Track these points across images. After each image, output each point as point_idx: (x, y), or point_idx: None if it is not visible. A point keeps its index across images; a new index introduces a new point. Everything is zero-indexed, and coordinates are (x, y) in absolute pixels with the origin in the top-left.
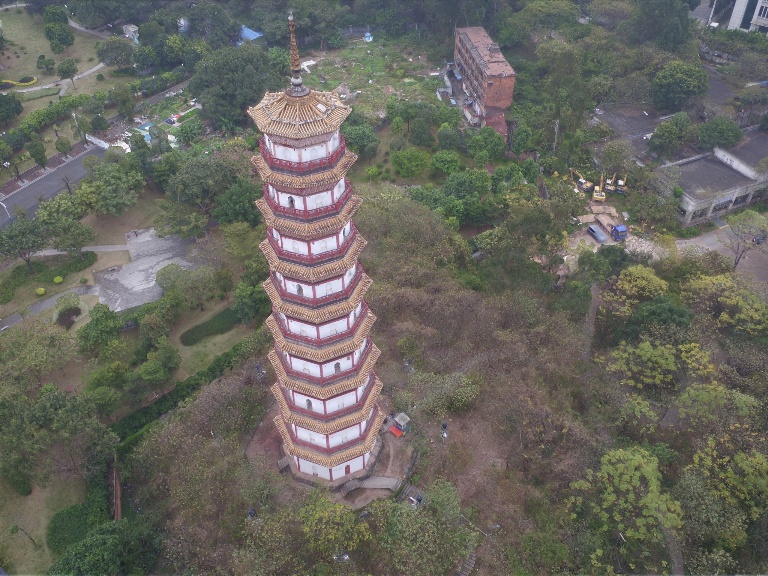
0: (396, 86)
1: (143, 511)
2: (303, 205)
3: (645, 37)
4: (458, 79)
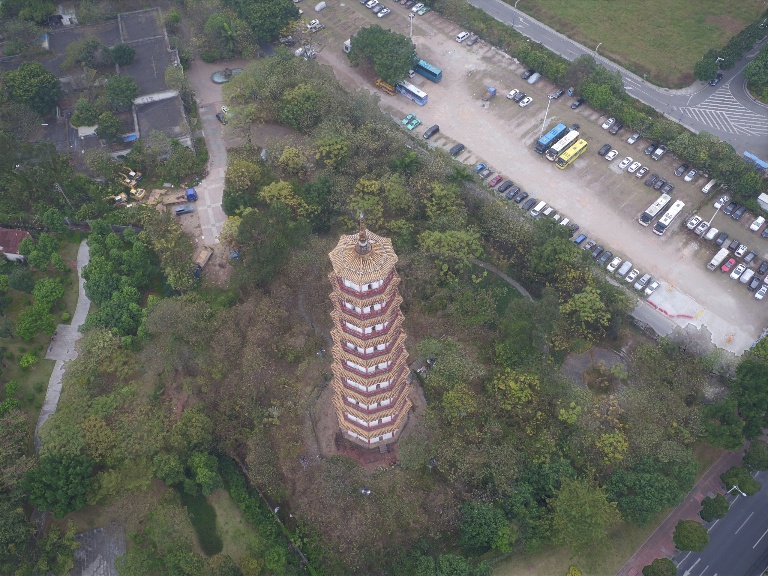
0: None
1: (390, 569)
2: None
3: None
4: None
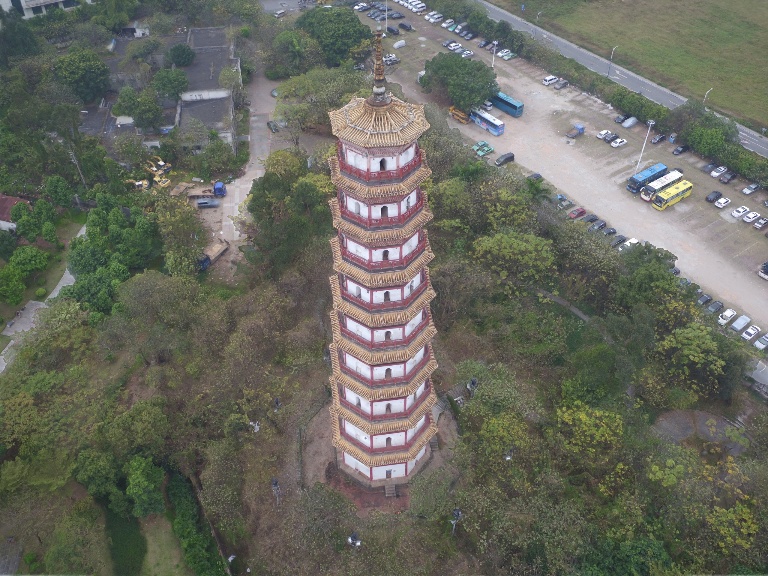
0: None
1: None
2: (416, 197)
3: (2, 55)
4: None
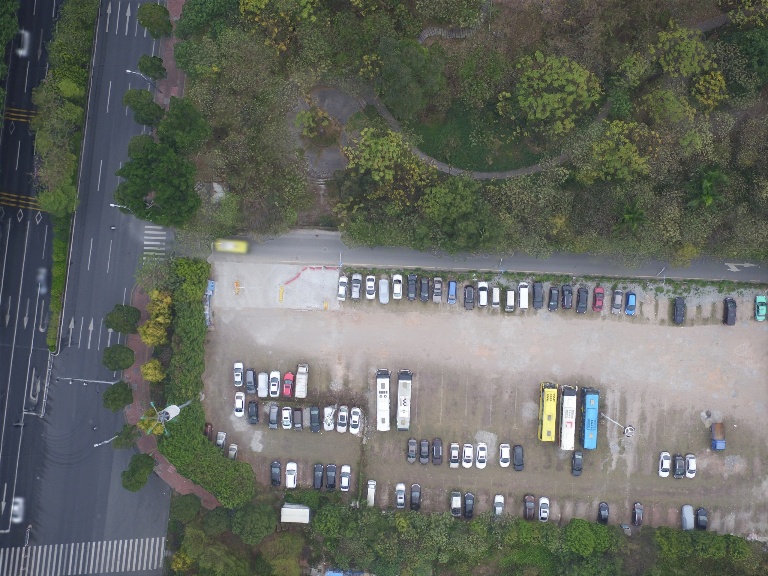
0: None
1: None
2: None
3: None
4: None
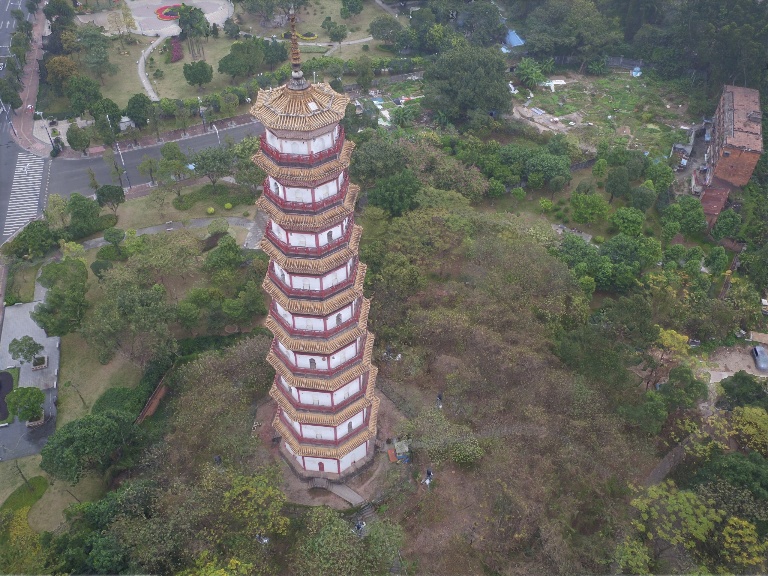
0: (635, 129)
1: (167, 418)
2: (283, 194)
3: None
4: (706, 140)
